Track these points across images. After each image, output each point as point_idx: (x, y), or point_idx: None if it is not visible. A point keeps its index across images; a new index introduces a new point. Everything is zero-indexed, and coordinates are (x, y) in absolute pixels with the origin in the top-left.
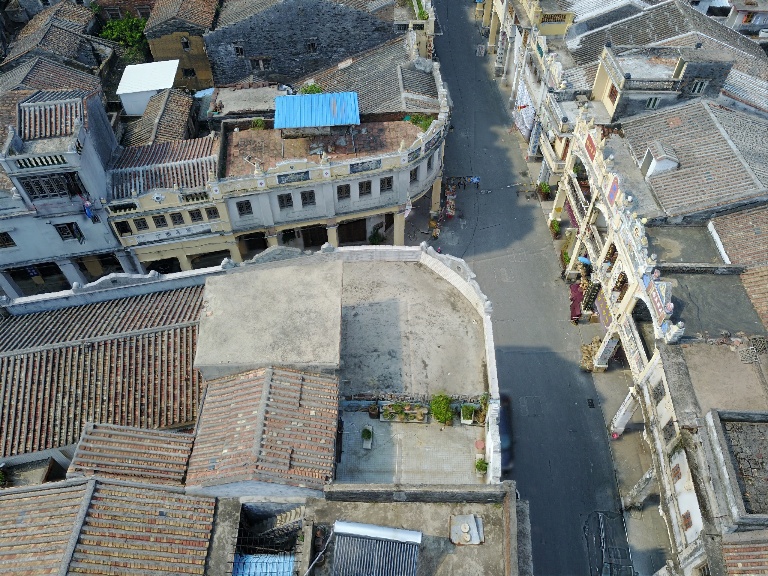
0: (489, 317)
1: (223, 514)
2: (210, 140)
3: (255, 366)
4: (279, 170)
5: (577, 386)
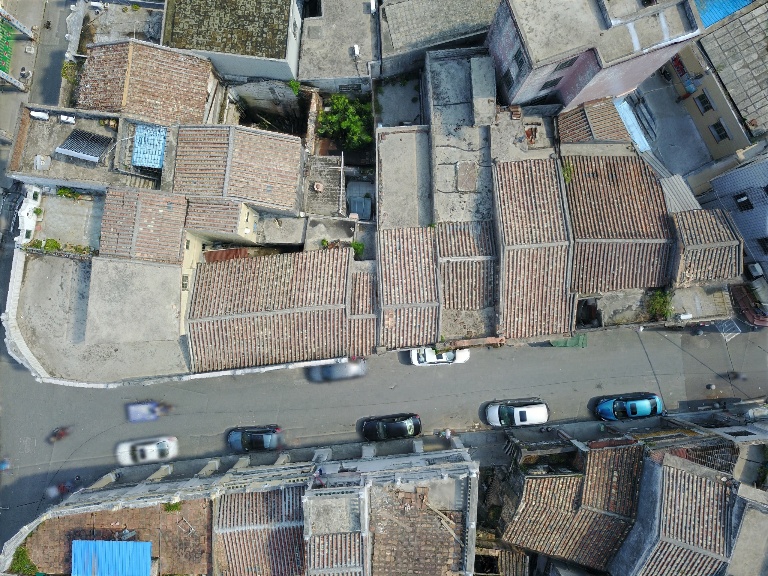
0: (7, 310)
1: (170, 186)
2: (233, 572)
3: (142, 261)
4: (157, 501)
5: (1, 332)
